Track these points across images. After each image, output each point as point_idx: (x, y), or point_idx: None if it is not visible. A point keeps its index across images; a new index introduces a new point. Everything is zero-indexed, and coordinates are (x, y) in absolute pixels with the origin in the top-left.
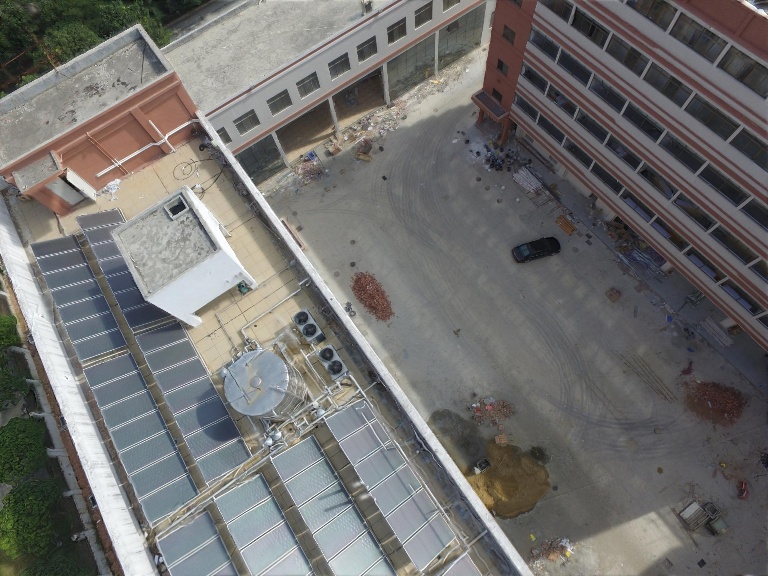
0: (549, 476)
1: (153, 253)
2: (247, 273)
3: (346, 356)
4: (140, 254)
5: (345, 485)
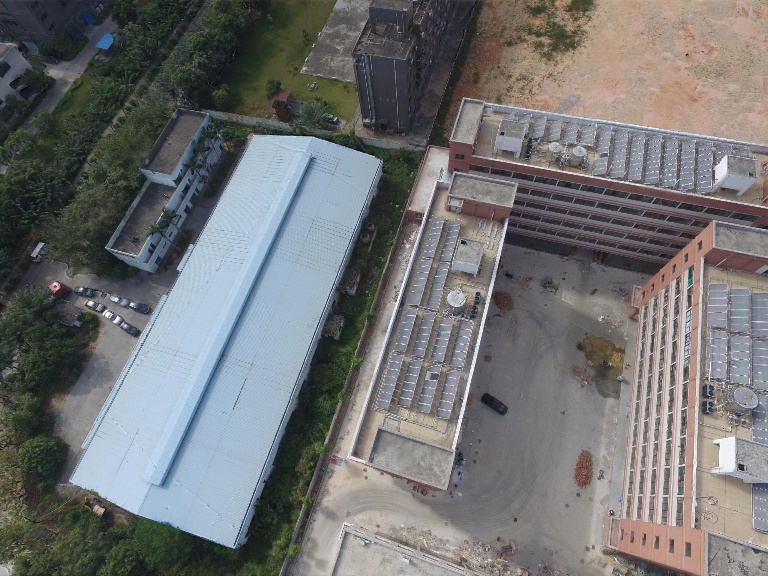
0: (584, 339)
1: (760, 460)
2: (720, 439)
3: (700, 392)
4: (765, 465)
5: (728, 364)
